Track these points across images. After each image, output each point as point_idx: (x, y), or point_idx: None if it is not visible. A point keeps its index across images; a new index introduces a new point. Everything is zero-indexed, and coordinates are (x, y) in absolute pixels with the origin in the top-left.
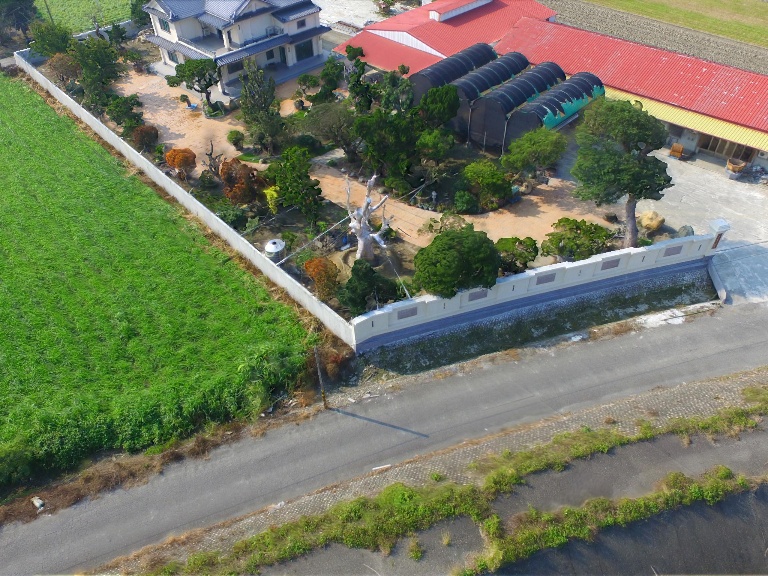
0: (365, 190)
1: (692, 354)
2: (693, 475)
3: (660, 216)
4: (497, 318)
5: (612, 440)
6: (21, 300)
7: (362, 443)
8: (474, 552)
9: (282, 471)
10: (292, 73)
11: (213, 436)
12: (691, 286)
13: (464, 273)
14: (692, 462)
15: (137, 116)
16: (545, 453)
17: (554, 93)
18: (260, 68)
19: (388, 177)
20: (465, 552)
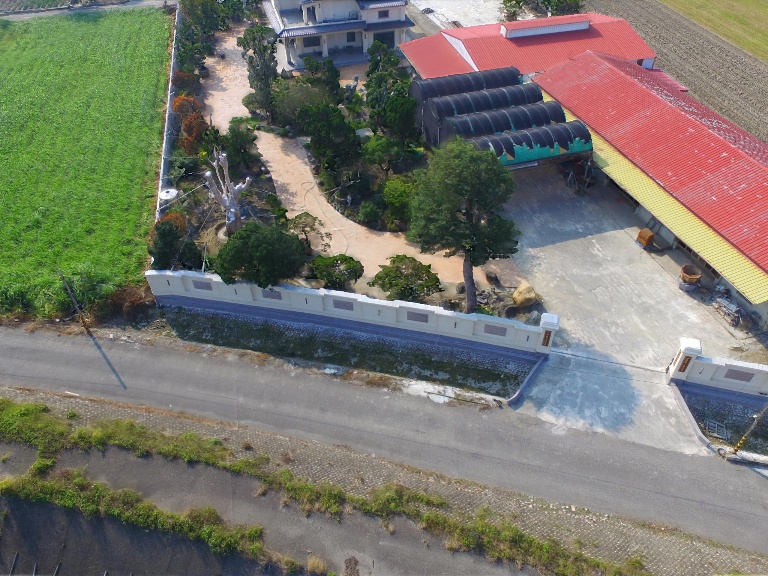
0: (308, 177)
1: (414, 434)
2: (230, 520)
3: (532, 293)
4: (292, 325)
5: (202, 455)
6: (3, 176)
7: (80, 370)
8: (12, 476)
9: (14, 362)
10: (362, 59)
11: (7, 318)
12: (513, 377)
13: (247, 266)
14: (244, 510)
15: (199, 64)
16: (149, 438)
17: (516, 133)
18: (337, 48)
19: (323, 170)
20: (7, 472)
